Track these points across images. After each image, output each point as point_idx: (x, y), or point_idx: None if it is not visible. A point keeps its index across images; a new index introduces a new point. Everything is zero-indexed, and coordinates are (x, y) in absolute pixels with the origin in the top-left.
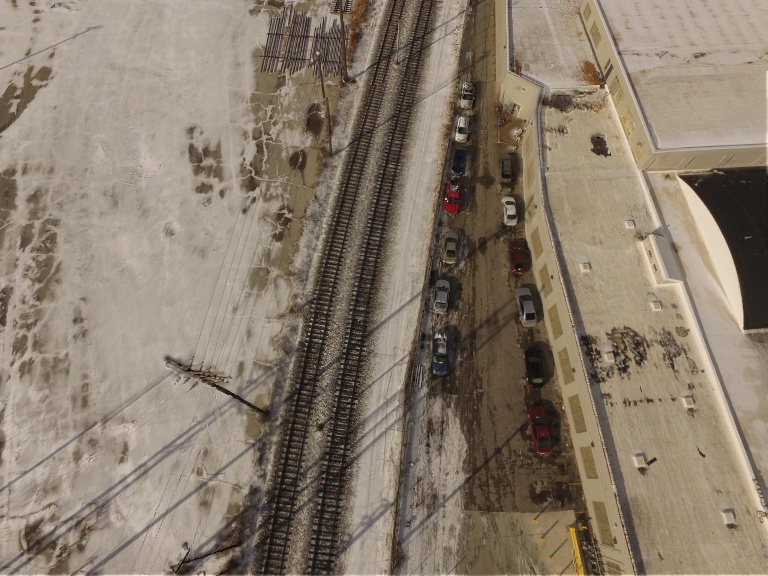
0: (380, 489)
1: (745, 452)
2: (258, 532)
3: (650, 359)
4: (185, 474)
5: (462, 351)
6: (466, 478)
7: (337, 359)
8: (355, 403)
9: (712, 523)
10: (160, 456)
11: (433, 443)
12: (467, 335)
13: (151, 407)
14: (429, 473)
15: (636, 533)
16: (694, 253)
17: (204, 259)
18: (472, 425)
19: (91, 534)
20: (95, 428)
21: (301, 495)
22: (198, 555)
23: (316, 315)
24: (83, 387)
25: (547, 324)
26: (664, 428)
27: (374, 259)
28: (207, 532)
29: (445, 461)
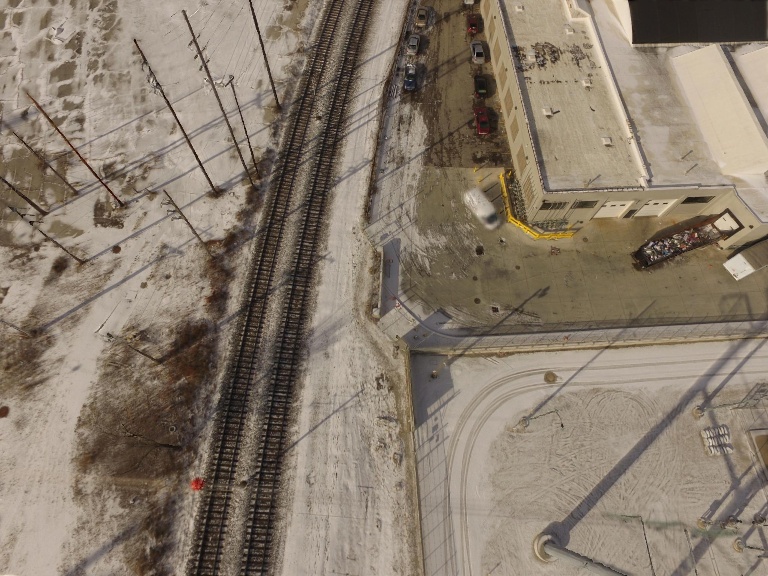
0: (362, 153)
1: (623, 106)
2: (272, 174)
3: (562, 60)
4: (219, 141)
5: (427, 78)
6: (426, 148)
7: (333, 80)
8: (345, 106)
9: (595, 144)
10: (200, 130)
11: (403, 129)
12: (432, 69)
13: (193, 104)
14: (399, 145)
15: (540, 147)
16: (602, 3)
17: (231, 19)
18: (432, 120)
19: (151, 171)
20: (151, 114)
21: (304, 155)
22: (229, 184)
23: (317, 55)
24: (142, 91)
25: (493, 62)
26: (567, 96)
27: (363, 23)
28: (235, 172)
29: (411, 139)
